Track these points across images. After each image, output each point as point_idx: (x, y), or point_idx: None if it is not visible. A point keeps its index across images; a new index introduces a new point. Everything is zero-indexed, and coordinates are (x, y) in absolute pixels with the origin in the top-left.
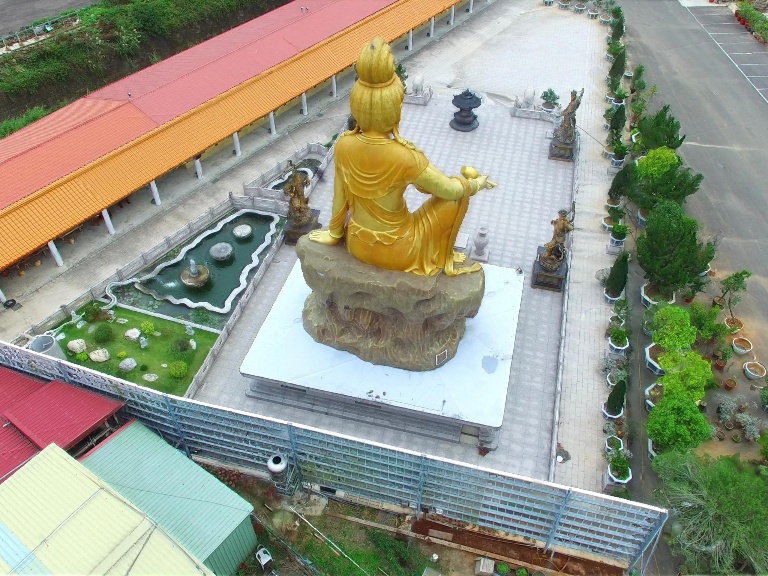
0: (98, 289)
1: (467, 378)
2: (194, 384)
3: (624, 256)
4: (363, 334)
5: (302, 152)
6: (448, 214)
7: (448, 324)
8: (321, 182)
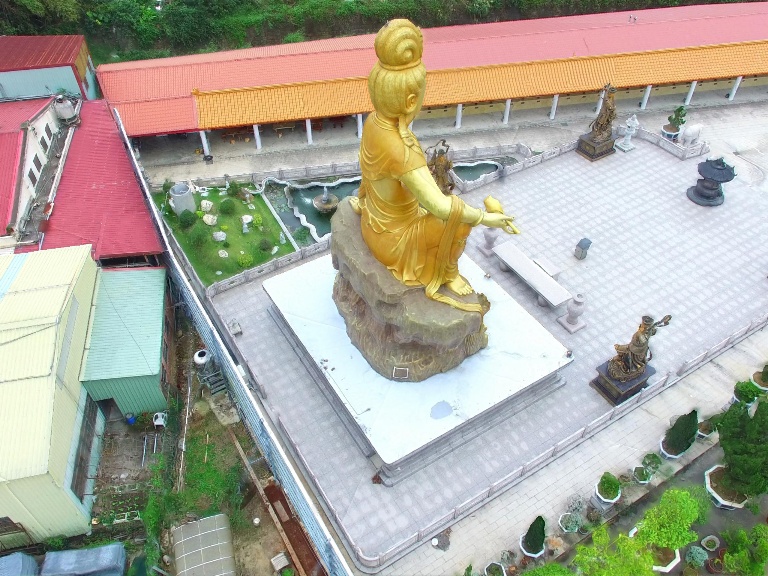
0: (259, 176)
1: (409, 406)
2: (242, 276)
3: (694, 410)
4: (353, 309)
5: (509, 148)
6: (435, 231)
7: (403, 340)
8: (500, 182)
